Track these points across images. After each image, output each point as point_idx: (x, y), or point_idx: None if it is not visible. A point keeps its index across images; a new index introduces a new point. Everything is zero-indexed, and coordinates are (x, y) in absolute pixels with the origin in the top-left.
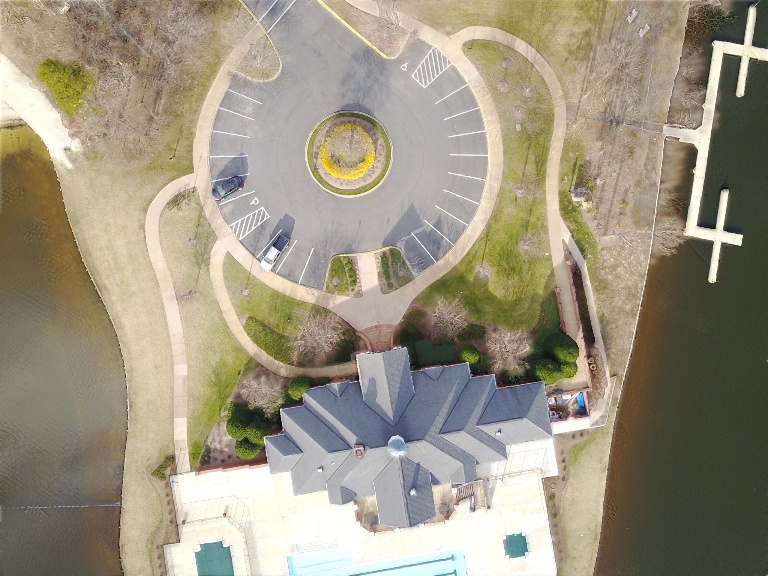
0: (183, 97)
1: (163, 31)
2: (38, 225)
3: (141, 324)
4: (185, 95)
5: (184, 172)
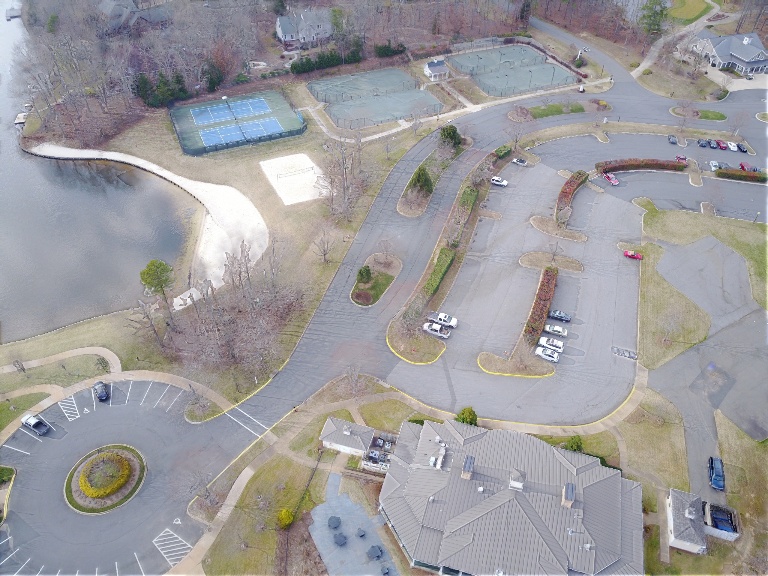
0: (184, 364)
1: (238, 351)
2: (121, 299)
3: (23, 351)
4: (185, 365)
5: (124, 366)
